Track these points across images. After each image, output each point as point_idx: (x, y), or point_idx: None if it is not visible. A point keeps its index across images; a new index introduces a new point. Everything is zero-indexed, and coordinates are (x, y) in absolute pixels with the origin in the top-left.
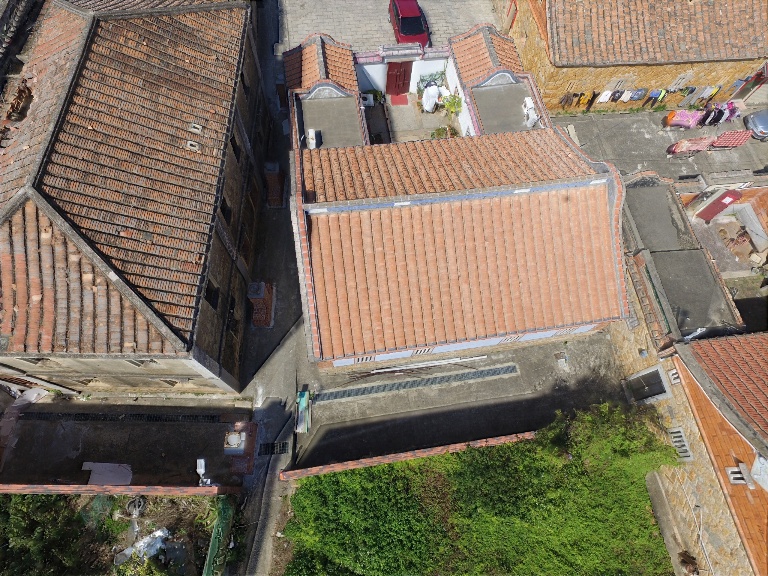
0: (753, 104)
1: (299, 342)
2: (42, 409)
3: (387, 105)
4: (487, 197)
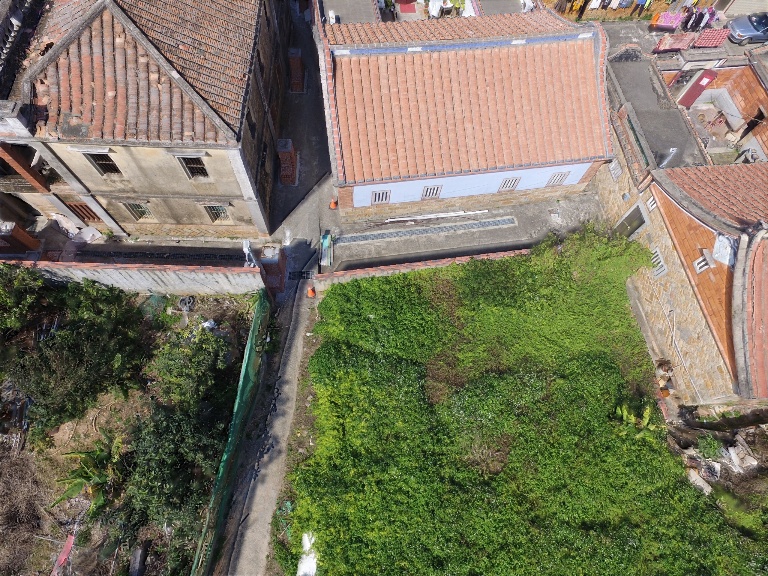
0: (733, 16)
1: (321, 197)
2: (96, 248)
3: (397, 12)
4: (488, 47)
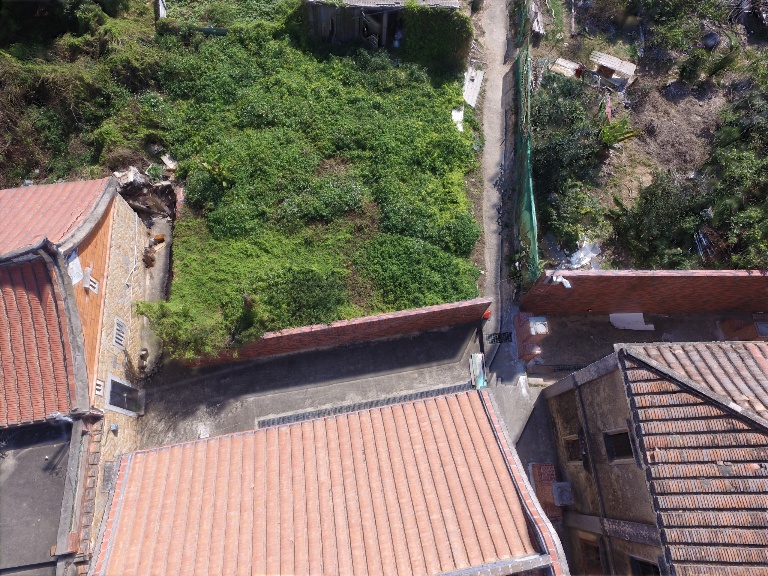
0: None
1: None
2: None
3: None
4: None
